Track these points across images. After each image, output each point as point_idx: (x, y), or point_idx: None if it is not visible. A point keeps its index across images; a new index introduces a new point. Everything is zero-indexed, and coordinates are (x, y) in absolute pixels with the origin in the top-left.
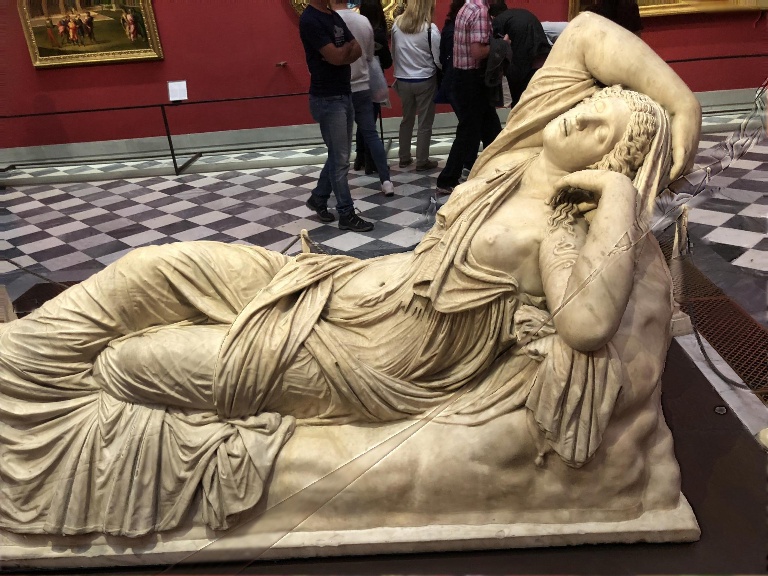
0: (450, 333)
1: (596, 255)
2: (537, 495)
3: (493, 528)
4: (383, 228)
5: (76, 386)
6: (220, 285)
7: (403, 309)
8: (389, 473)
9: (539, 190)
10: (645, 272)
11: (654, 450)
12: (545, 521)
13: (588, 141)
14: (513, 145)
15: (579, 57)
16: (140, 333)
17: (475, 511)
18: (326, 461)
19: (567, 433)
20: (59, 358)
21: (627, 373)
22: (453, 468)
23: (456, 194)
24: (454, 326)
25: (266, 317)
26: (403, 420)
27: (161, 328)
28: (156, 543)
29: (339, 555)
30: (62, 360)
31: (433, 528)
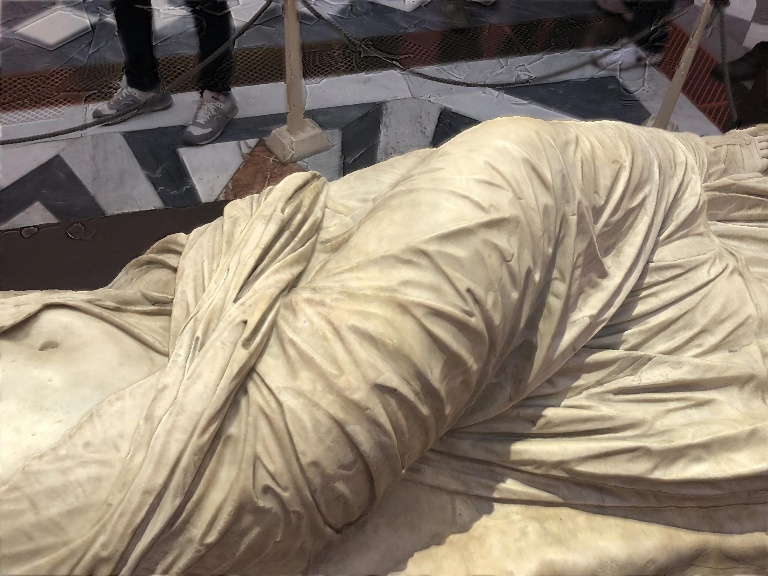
0: None
1: None
2: None
3: None
4: None
5: None
6: None
7: None
8: None
9: None
10: None
11: None
12: None
13: None
14: None
15: None
16: None
17: None
18: None
19: None
20: None
21: None
22: None
23: None
24: None
25: None
26: None
27: None
28: None
29: None
30: None
31: None
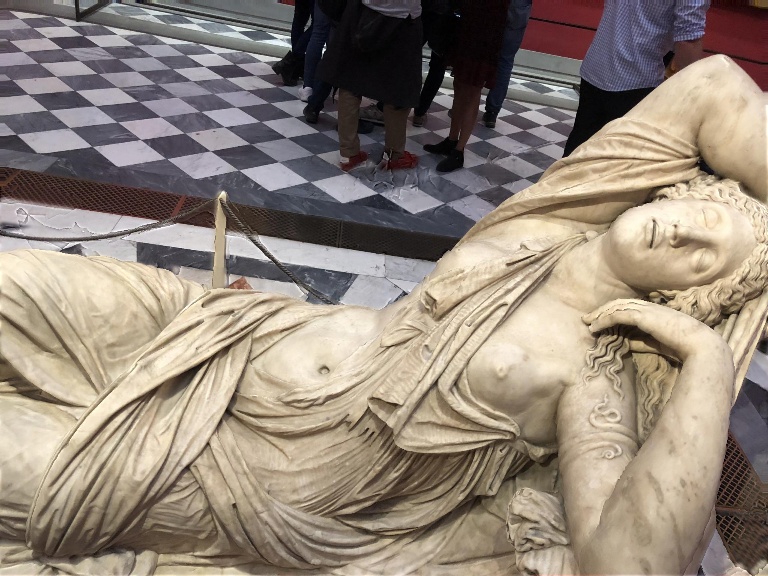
0: (406, 471)
1: (672, 483)
2: None
3: None
4: (319, 167)
5: None
6: (71, 340)
7: (347, 424)
8: None
9: (577, 295)
10: None
11: None
12: None
13: (679, 265)
14: (552, 210)
15: (693, 123)
16: None
17: None
18: None
19: None
20: None
21: None
22: None
23: (457, 265)
24: (415, 464)
25: (136, 417)
26: (314, 571)
27: None
28: None
29: None
30: None
31: None
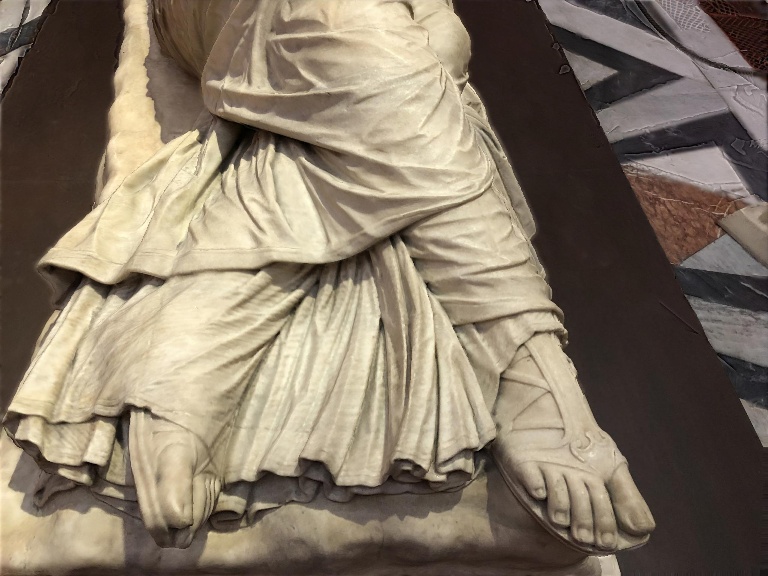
0: None
1: None
2: None
3: None
4: None
5: None
6: None
7: None
8: None
9: None
10: None
11: None
12: None
13: None
14: None
15: None
16: None
17: None
18: None
19: None
20: None
21: None
22: None
23: None
24: None
25: None
26: None
27: None
28: None
29: None
30: None
31: None
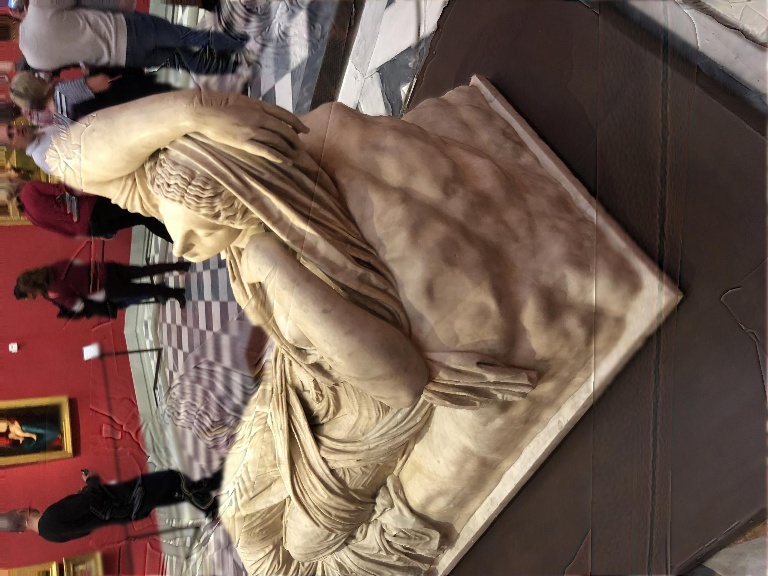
0: None
1: (330, 363)
2: (546, 395)
3: (553, 423)
4: None
5: (308, 570)
6: (265, 478)
7: None
8: (463, 467)
9: None
10: (380, 240)
11: (570, 296)
12: (573, 392)
13: None
14: None
15: None
16: (285, 528)
17: (531, 428)
18: (432, 489)
19: (497, 397)
20: (284, 575)
21: (469, 345)
22: (484, 437)
23: None
24: None
25: (300, 481)
26: (432, 412)
27: (286, 516)
28: (436, 569)
29: (507, 504)
30: (286, 574)
31: (526, 452)
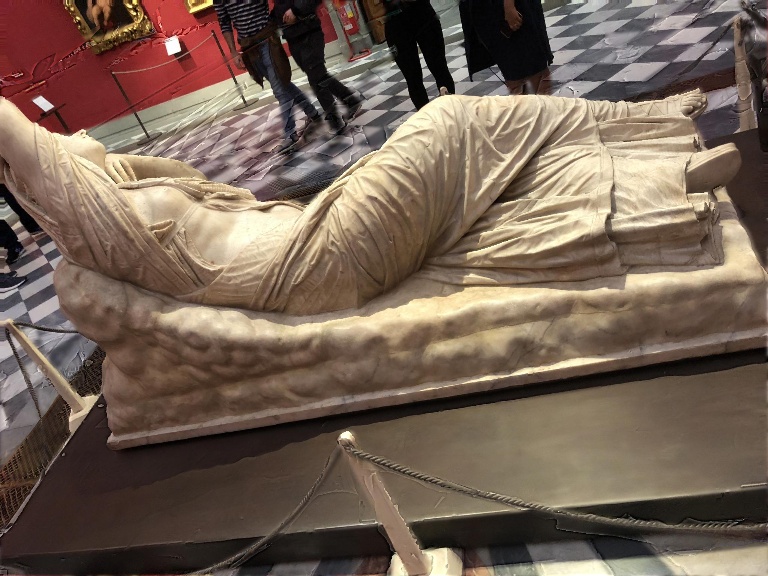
0: None
1: None
2: None
3: None
4: None
5: None
6: None
7: None
8: None
9: None
10: None
11: None
12: None
13: None
14: None
15: None
16: None
17: None
18: None
19: None
20: None
21: None
22: None
23: None
24: None
25: None
26: None
27: None
28: None
29: None
30: None
31: None
